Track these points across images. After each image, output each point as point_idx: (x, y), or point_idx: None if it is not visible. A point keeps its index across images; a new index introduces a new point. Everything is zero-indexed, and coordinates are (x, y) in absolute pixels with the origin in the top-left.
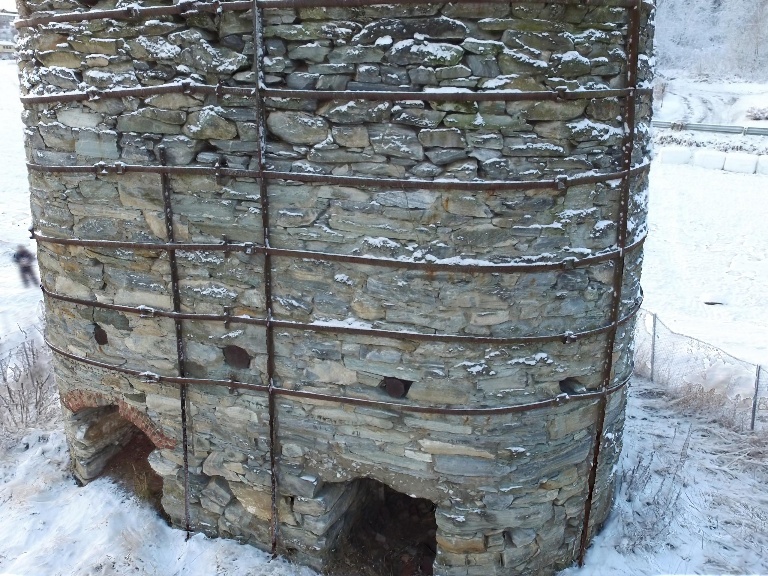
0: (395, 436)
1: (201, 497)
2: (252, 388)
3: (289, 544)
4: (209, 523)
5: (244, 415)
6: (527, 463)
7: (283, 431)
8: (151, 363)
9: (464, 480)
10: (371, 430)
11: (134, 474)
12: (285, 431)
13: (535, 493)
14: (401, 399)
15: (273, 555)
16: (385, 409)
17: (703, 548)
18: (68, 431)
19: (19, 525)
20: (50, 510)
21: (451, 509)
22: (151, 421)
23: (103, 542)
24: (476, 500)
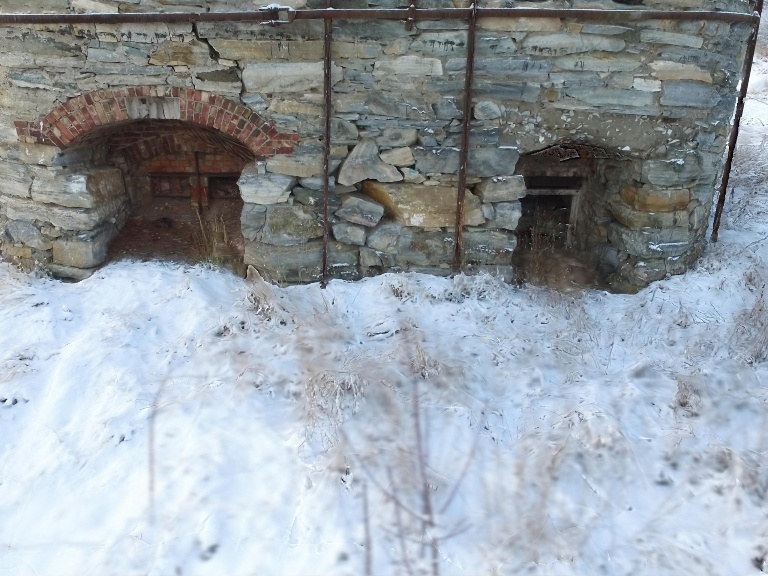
0: (625, 61)
1: (335, 223)
2: (444, 15)
3: (472, 254)
4: (346, 262)
5: (423, 66)
6: (726, 95)
7: (480, 80)
8: (263, 2)
9: (686, 112)
10: (597, 58)
11: (167, 251)
12: (483, 80)
13: (719, 138)
14: (640, 5)
15: (451, 275)
16: (617, 24)
17: (766, 225)
18: (42, 191)
19: (20, 321)
20: (64, 298)
21: (670, 153)
22: (252, 111)
23: (204, 306)
24: (689, 141)
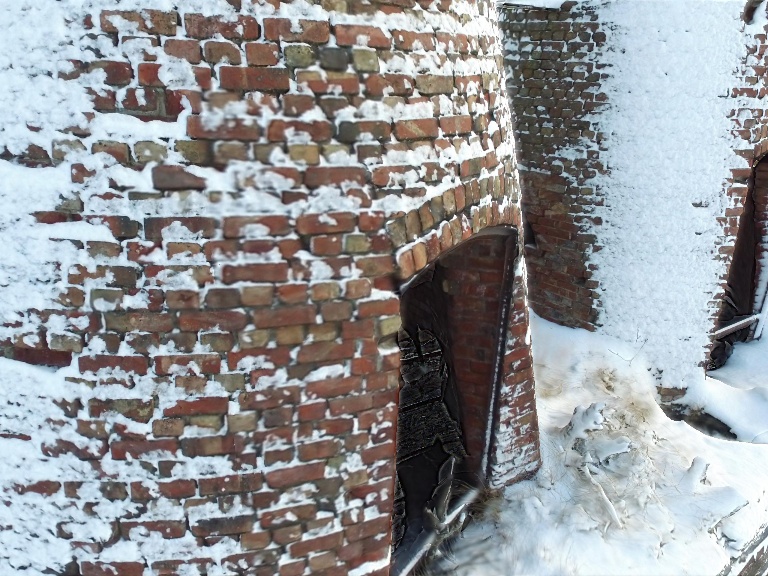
0: None
1: None
2: None
3: None
4: None
5: None
6: None
7: None
8: None
9: None
10: None
11: None
12: None
13: None
14: None
15: None
16: None
17: None
18: None
19: None
20: None
21: None
22: None
23: None
24: None
